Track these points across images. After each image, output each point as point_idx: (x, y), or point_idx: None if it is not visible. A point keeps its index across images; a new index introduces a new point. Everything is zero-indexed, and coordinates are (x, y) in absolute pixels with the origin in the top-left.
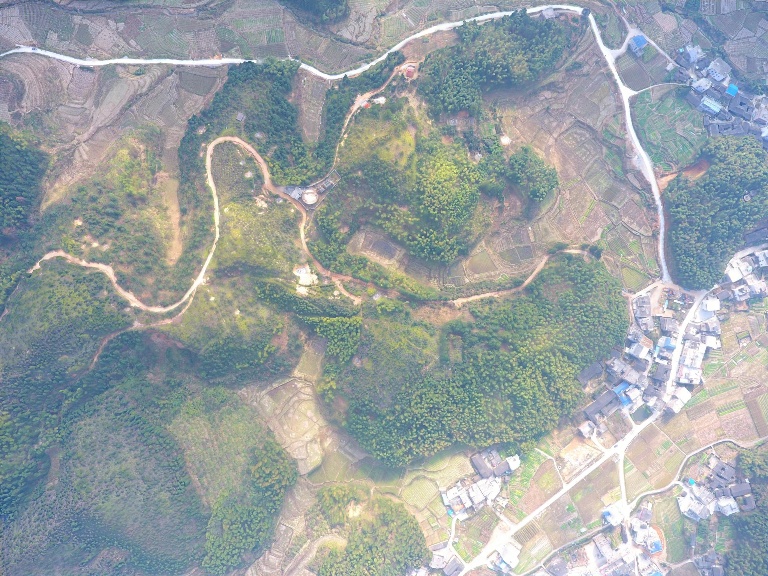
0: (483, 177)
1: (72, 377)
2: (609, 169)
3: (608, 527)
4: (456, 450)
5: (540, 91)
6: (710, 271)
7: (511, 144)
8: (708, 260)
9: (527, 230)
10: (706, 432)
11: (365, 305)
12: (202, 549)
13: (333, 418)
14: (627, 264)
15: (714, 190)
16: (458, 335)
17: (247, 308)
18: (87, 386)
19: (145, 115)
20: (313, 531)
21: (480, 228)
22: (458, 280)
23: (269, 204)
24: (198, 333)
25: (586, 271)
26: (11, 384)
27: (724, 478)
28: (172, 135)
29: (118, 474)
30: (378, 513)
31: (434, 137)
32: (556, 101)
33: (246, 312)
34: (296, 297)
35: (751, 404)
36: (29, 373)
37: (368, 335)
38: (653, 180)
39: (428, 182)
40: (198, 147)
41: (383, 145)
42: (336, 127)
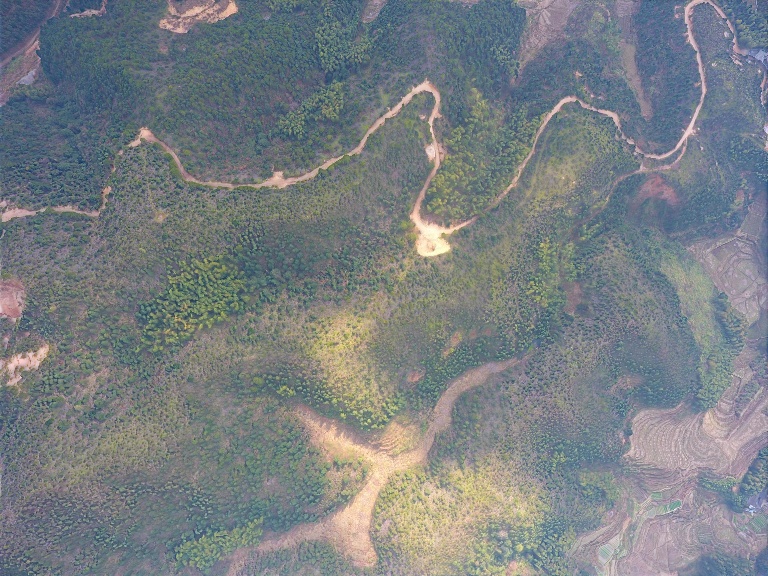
0: None
1: None
2: None
3: None
4: None
5: None
6: None
7: None
8: None
9: None
10: None
11: None
12: (695, 383)
13: None
14: None
15: None
16: None
17: None
18: None
19: None
20: (765, 379)
21: None
22: None
23: (743, 63)
24: (692, 180)
25: None
26: (553, 214)
27: None
28: (621, 5)
29: (648, 301)
30: None
31: None
32: None
33: (724, 164)
34: (766, 152)
35: None
36: (566, 205)
37: None
38: None
39: None
40: (672, 9)
41: None
42: None
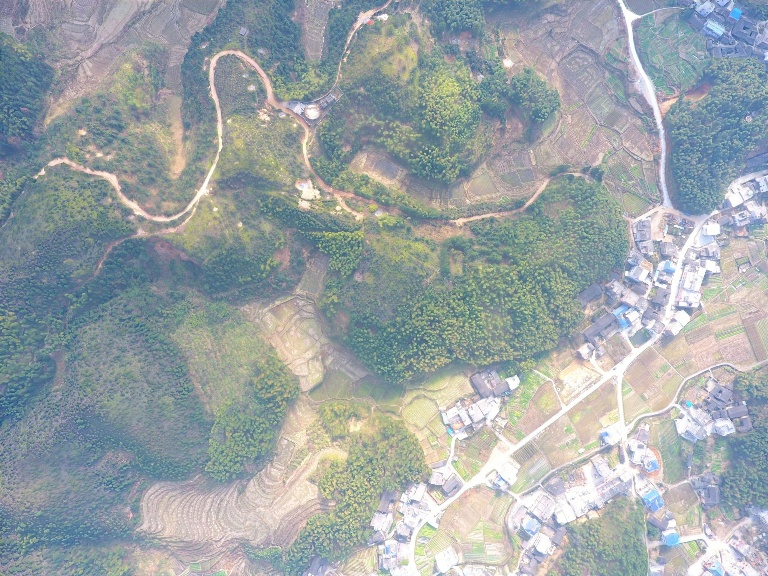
0: (485, 96)
1: (77, 282)
2: (611, 94)
3: (606, 448)
4: (456, 370)
5: (543, 14)
6: (711, 193)
7: (513, 67)
8: (709, 181)
9: (529, 153)
10: (704, 356)
11: (367, 221)
12: (205, 455)
13: (335, 335)
14: (628, 189)
15: (716, 110)
16: (459, 250)
17: (250, 221)
18: (92, 292)
19: (148, 33)
20: (314, 444)
21: (482, 149)
22: (459, 201)
23: (272, 118)
24: (201, 243)
25: (587, 189)
26: (17, 285)
27: (721, 400)
28: (175, 53)
29: (123, 375)
30: (379, 427)
31: (436, 54)
32: (559, 25)
33: (249, 224)
34: (298, 211)
35: (749, 329)
36: (35, 275)
37: (370, 249)
38: (655, 104)
39: (430, 96)
40: (201, 61)
41: (386, 59)
42: (339, 44)
